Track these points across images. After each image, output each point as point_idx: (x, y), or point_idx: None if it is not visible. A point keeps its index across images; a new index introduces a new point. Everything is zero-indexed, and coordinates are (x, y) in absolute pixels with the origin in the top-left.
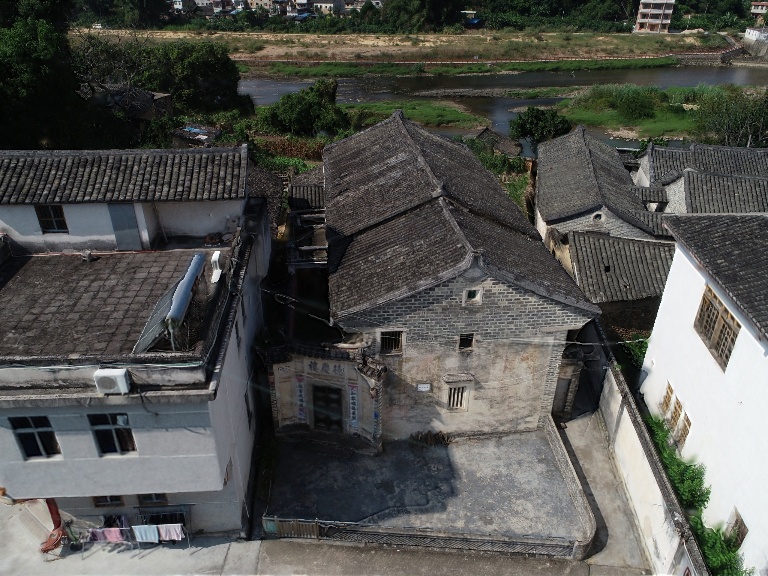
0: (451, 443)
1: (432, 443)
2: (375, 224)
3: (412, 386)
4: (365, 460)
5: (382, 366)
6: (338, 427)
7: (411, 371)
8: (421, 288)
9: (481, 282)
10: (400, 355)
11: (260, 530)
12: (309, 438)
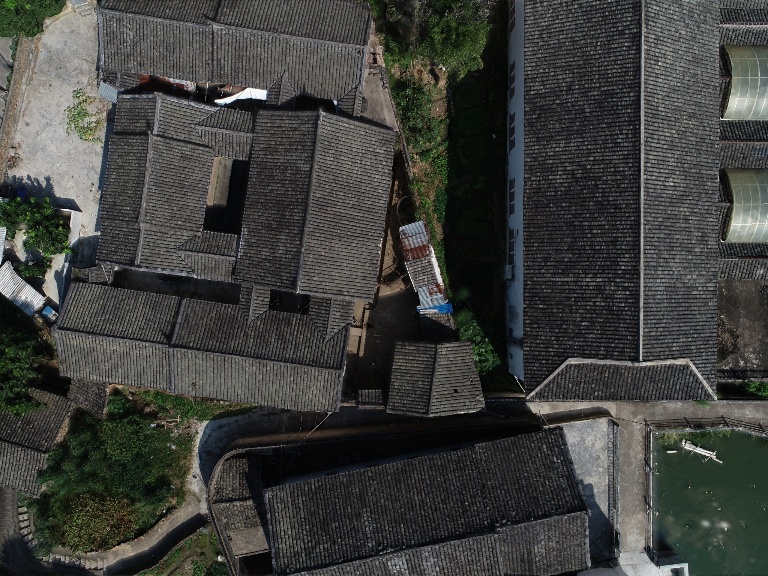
0: None
1: None
2: None
3: None
4: None
5: None
6: None
7: None
8: None
9: None
10: None
11: (612, 555)
12: None
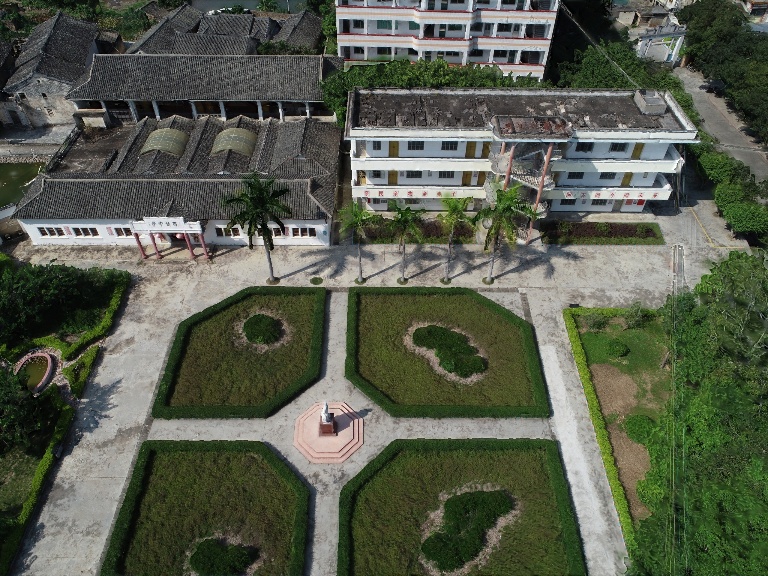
0: (55, 126)
1: (49, 127)
2: (25, 63)
3: (35, 109)
4: (28, 131)
5: (20, 102)
6: (20, 123)
7: (33, 104)
8: (22, 80)
9: (39, 78)
10: (27, 100)
11: None
12: (13, 127)
